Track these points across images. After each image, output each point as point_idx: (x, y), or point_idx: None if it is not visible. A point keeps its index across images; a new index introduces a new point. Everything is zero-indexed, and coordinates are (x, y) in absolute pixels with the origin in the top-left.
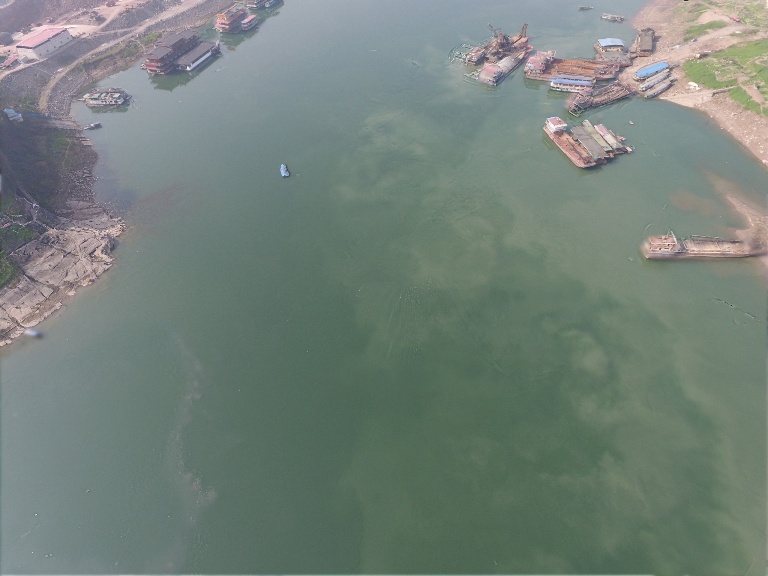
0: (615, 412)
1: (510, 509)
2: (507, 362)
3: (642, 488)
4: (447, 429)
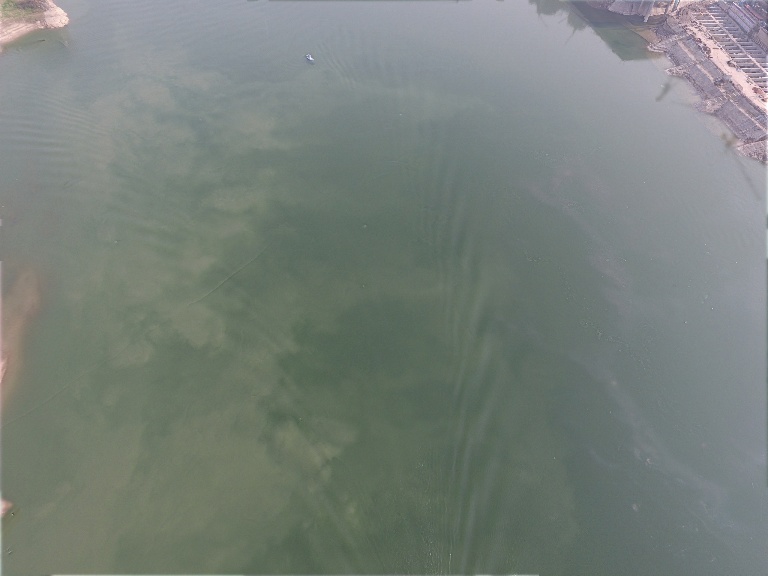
0: (225, 406)
1: (345, 327)
2: (316, 464)
3: (239, 340)
4: (391, 376)
